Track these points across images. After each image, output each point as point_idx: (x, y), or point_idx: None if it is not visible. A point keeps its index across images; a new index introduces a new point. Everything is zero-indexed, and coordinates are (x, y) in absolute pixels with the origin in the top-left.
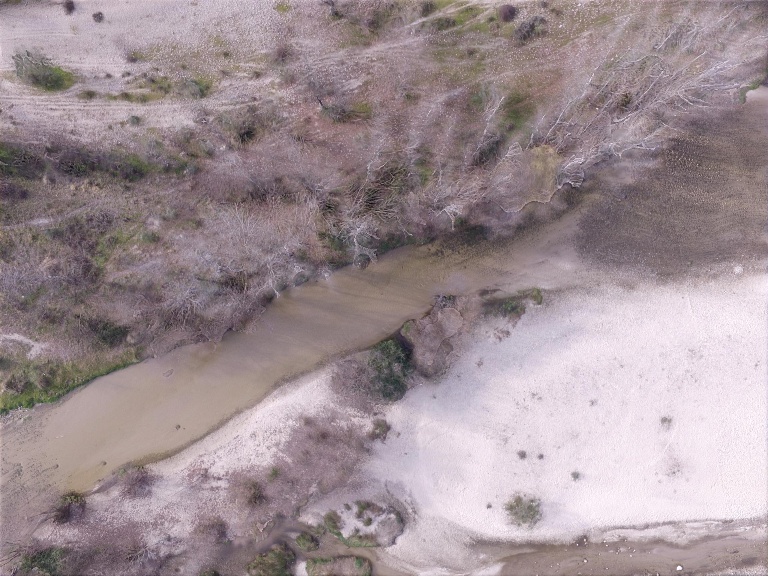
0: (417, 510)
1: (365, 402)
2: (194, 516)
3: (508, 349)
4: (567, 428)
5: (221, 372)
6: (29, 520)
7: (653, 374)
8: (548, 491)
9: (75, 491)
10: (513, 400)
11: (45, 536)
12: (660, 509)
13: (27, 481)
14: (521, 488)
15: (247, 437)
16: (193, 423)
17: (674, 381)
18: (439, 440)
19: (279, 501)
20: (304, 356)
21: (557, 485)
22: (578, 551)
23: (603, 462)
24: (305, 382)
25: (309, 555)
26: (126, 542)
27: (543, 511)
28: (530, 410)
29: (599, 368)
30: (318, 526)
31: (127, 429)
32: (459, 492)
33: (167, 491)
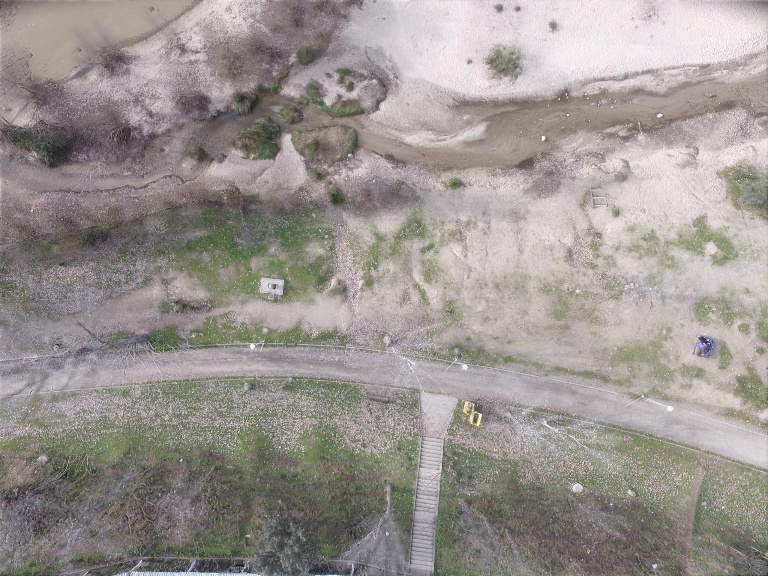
0: (399, 75)
1: None
2: (175, 92)
3: None
4: None
5: None
6: (7, 110)
7: None
8: (527, 43)
9: (52, 79)
10: None
11: (25, 123)
12: (638, 55)
13: (2, 71)
14: (500, 42)
15: (223, 11)
16: (167, 5)
17: None
18: (416, 2)
19: (260, 71)
20: None
21: (536, 37)
22: (560, 106)
23: (580, 11)
24: None
25: (294, 128)
26: (108, 120)
27: (523, 64)
28: None
29: None
30: (301, 97)
31: (100, 14)
32: (439, 51)
33: (145, 69)
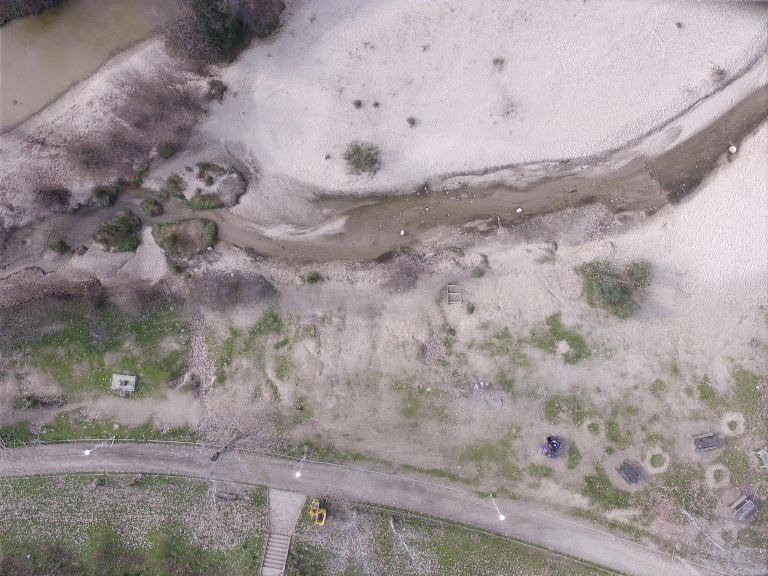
0: (258, 169)
1: (201, 66)
2: (35, 186)
3: (340, 3)
4: (401, 75)
5: (54, 45)
6: None
7: (483, 16)
8: (385, 139)
9: None
10: (346, 51)
11: None
12: (497, 151)
13: None
14: (358, 137)
15: (83, 105)
16: (30, 98)
17: (504, 22)
18: (276, 97)
19: (119, 165)
20: (137, 24)
21: (394, 133)
22: (420, 200)
23: (438, 107)
24: (139, 49)
25: (154, 220)
26: None
27: (382, 160)
28: (363, 59)
29: (430, 13)
30: (161, 190)
31: None
32: (298, 146)
33: (6, 162)
